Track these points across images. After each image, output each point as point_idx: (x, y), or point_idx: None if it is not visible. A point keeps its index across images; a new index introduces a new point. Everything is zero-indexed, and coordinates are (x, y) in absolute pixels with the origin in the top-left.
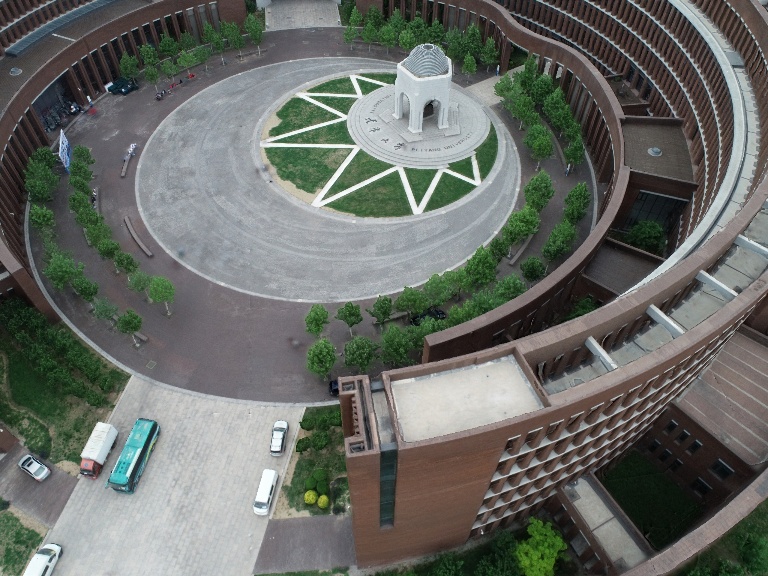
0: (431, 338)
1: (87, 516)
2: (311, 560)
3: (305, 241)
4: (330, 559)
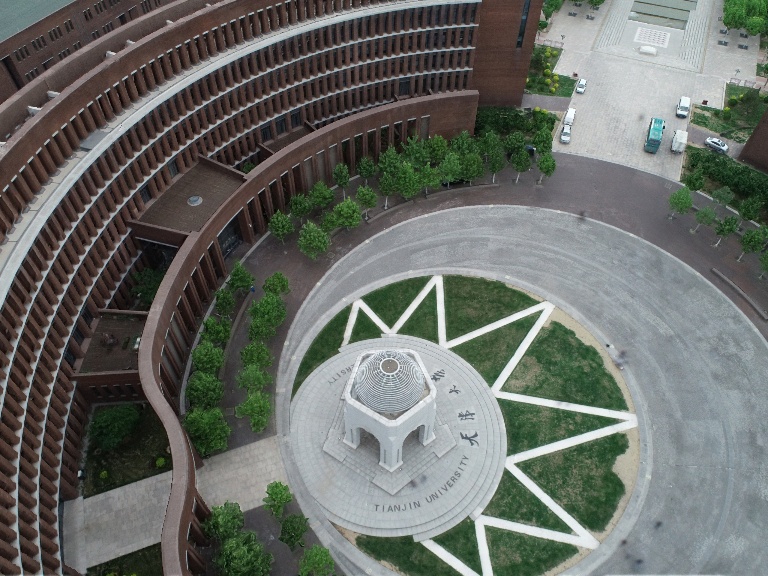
0: (476, 92)
1: (671, 126)
2: (542, 98)
3: (559, 263)
4: (533, 97)
